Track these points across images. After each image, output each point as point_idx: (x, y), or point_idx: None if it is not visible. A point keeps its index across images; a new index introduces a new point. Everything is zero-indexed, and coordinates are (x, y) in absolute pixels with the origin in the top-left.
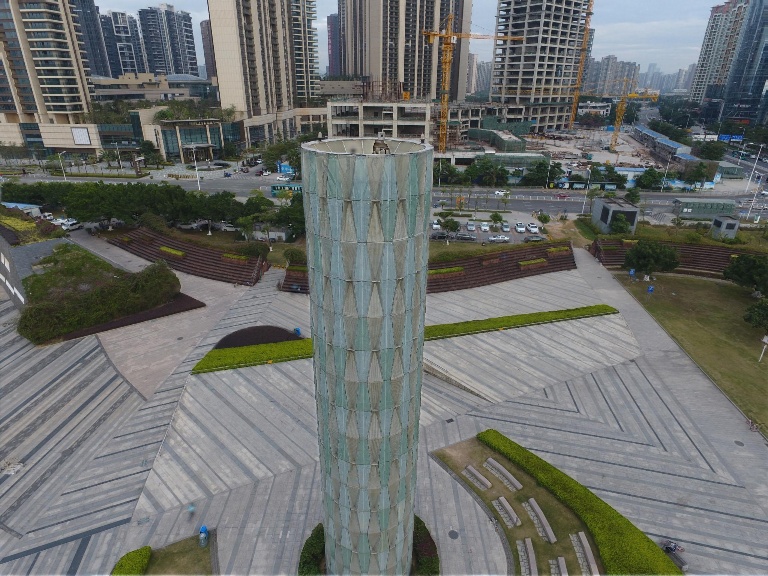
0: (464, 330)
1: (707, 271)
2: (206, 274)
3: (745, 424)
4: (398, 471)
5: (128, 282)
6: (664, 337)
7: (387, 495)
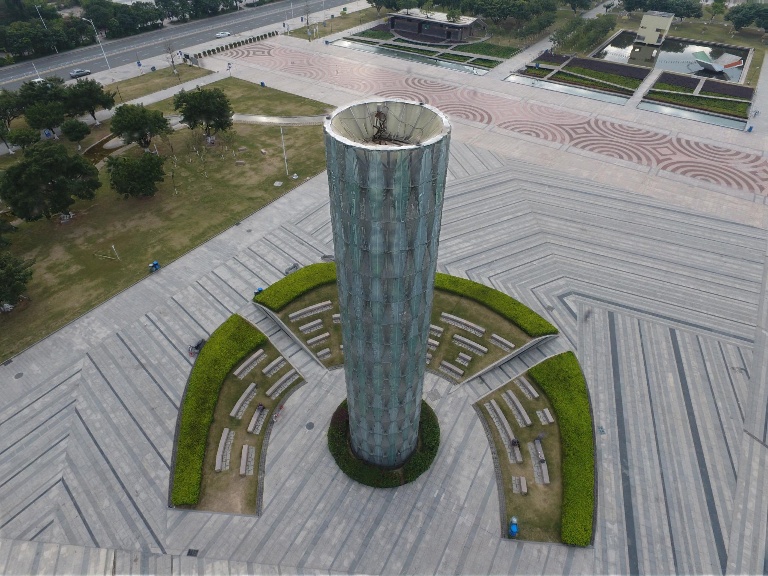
0: None
1: None
2: None
3: None
4: None
5: None
6: None
7: None
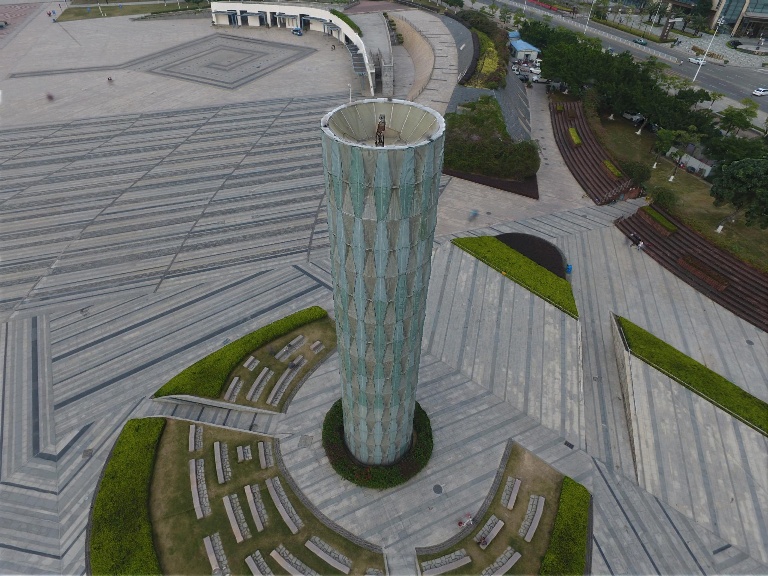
0: (730, 405)
1: None
2: (576, 172)
3: None
4: (358, 383)
5: (498, 148)
6: None
7: (352, 390)
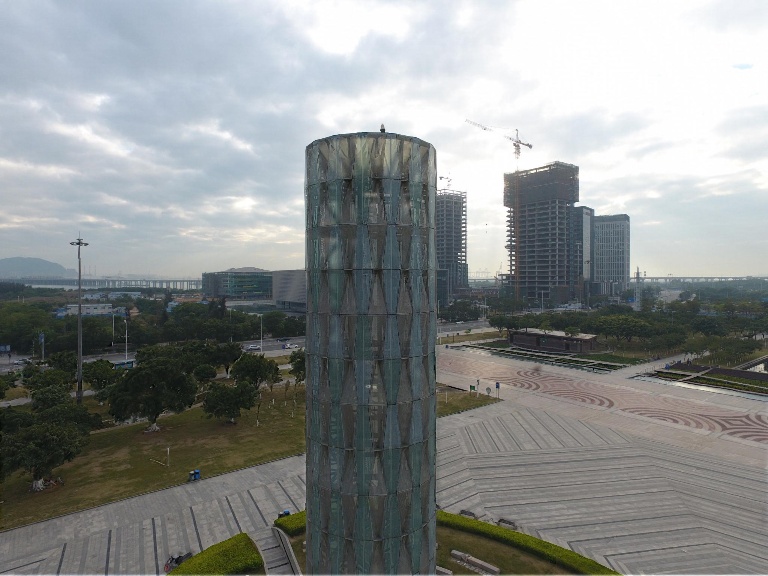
0: None
1: None
2: None
3: None
4: None
5: None
6: None
7: None
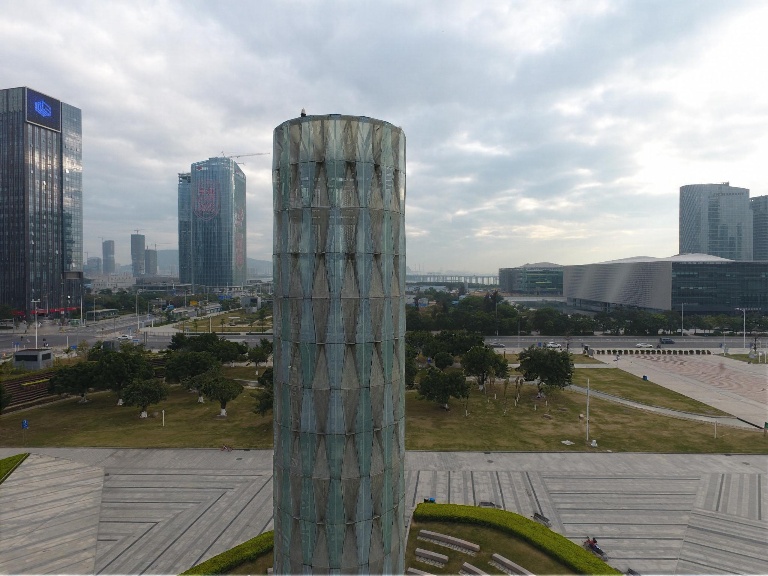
0: None
1: (13, 406)
2: None
3: (222, 451)
4: None
5: None
6: (89, 451)
7: None
